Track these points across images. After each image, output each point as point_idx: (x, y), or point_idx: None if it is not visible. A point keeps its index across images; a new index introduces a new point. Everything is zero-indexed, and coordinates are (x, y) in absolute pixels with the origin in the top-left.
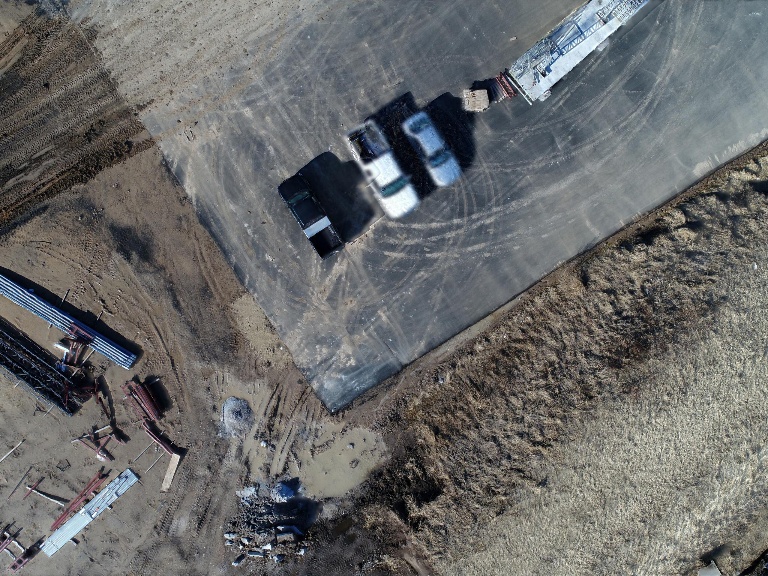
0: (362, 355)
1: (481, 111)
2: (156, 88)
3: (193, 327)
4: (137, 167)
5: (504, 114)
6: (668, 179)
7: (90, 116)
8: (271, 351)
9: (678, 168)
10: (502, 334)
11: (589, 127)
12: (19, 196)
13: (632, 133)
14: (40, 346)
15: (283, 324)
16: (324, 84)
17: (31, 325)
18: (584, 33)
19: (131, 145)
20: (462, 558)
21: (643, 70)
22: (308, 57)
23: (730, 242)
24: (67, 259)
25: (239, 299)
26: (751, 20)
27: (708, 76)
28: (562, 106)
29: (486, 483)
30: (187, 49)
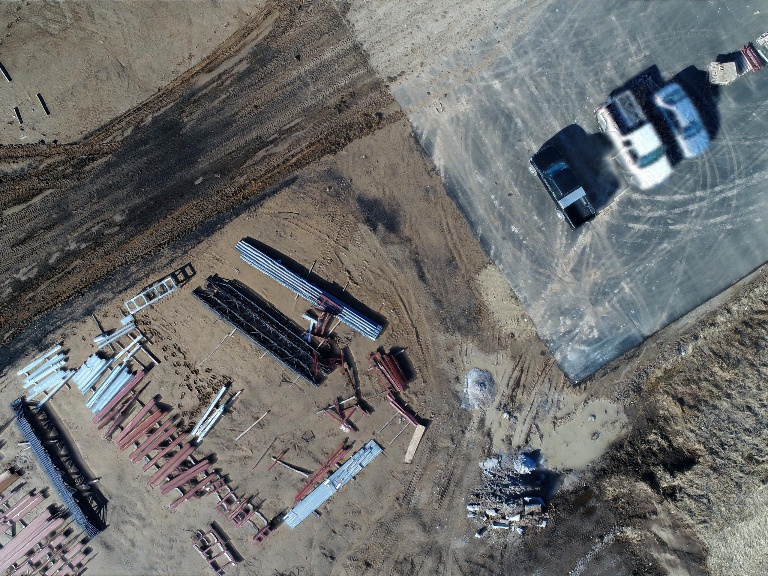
0: (605, 327)
1: (725, 84)
2: (407, 60)
3: (438, 298)
4: (386, 139)
5: (747, 87)
6: None
7: (341, 88)
8: (515, 322)
9: None
10: (744, 306)
11: None
12: (268, 167)
13: None
14: (287, 317)
15: (528, 295)
16: (571, 57)
17: (278, 296)
18: None
19: (381, 117)
20: (729, 527)
21: None
22: (556, 30)
23: None
24: (314, 230)
25: (484, 270)
26: None
27: None
28: None
29: (748, 452)
30: (438, 22)
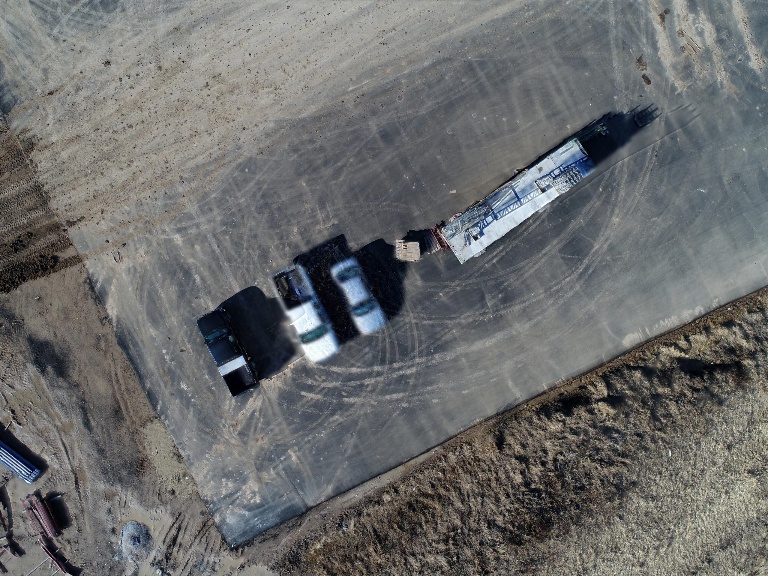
0: (268, 493)
1: (413, 261)
2: (88, 206)
3: (101, 447)
4: (61, 282)
5: (436, 266)
6: (596, 347)
7: (19, 227)
8: (176, 480)
9: (607, 337)
10: (411, 486)
11: (521, 287)
12: None
13: (564, 297)
14: None
15: (191, 454)
16: (257, 218)
17: None
18: (521, 200)
19: (57, 260)
20: None
21: (581, 236)
22: (244, 190)
23: (648, 424)
24: None
25: (150, 424)
26: (696, 196)
27: (647, 248)
28: (495, 264)
29: None
30: (123, 170)
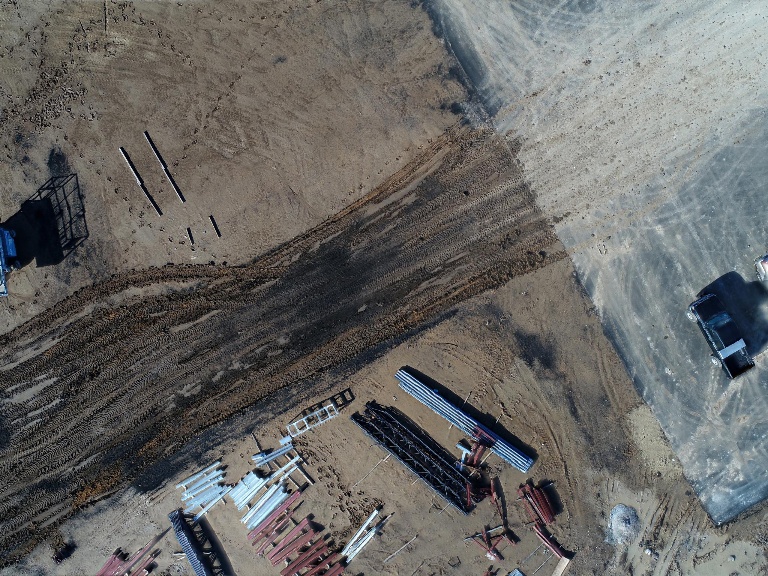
0: (750, 470)
1: None
2: (573, 202)
3: (588, 434)
4: (548, 277)
5: None
6: None
7: (507, 225)
8: (663, 462)
9: None
10: None
11: None
12: (430, 299)
13: None
14: (440, 445)
15: (677, 436)
16: (735, 205)
17: (433, 424)
18: None
19: (544, 255)
20: None
21: None
22: (722, 179)
23: None
24: (472, 362)
25: (635, 410)
26: None
27: None
28: None
29: None
30: (606, 165)
